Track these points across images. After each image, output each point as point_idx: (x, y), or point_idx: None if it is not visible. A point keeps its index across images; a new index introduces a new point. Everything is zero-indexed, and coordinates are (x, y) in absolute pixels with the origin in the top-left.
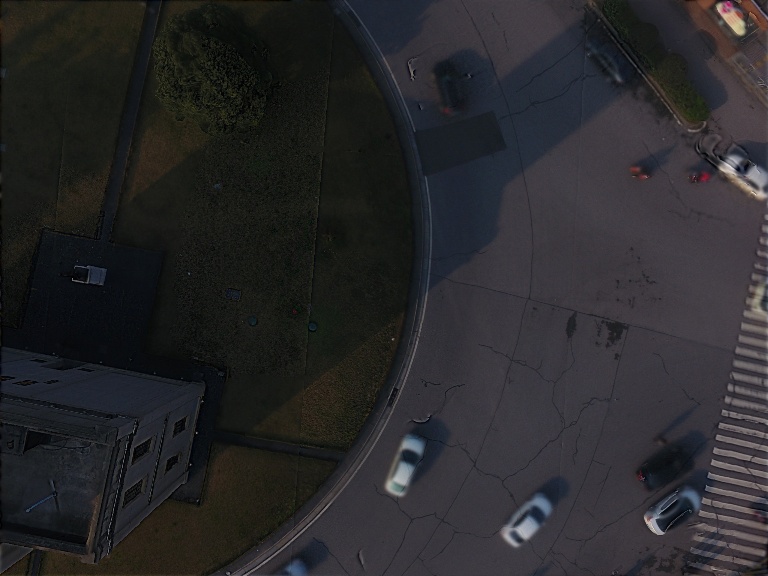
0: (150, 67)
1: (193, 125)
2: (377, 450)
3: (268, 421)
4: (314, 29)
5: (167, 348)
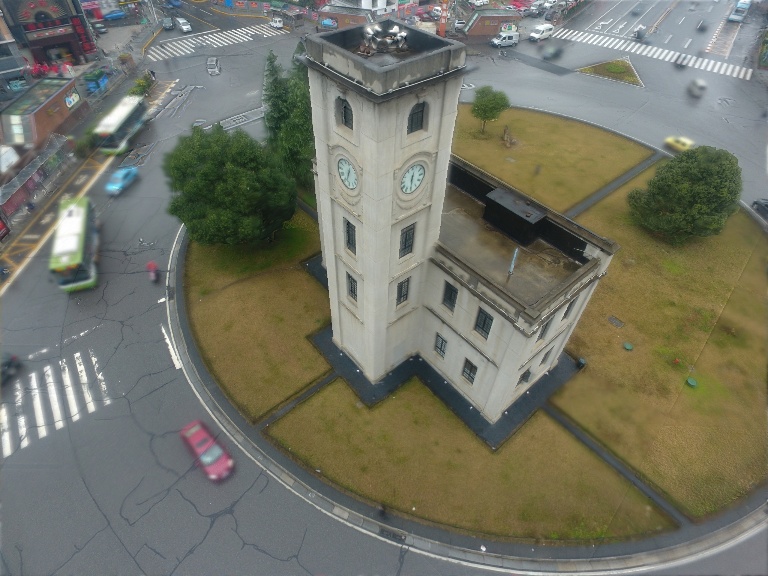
0: (609, 195)
1: (628, 228)
2: (737, 549)
3: (609, 428)
4: (744, 230)
5: None
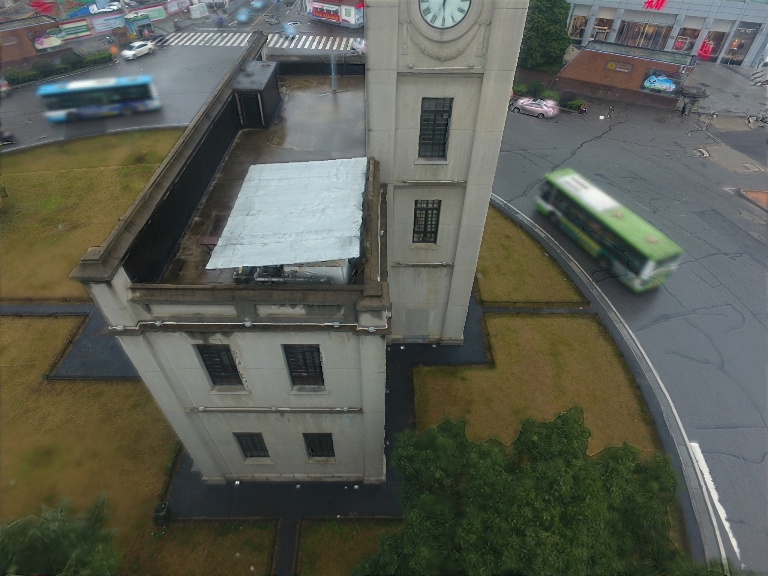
0: None
1: None
2: None
3: None
4: None
5: None
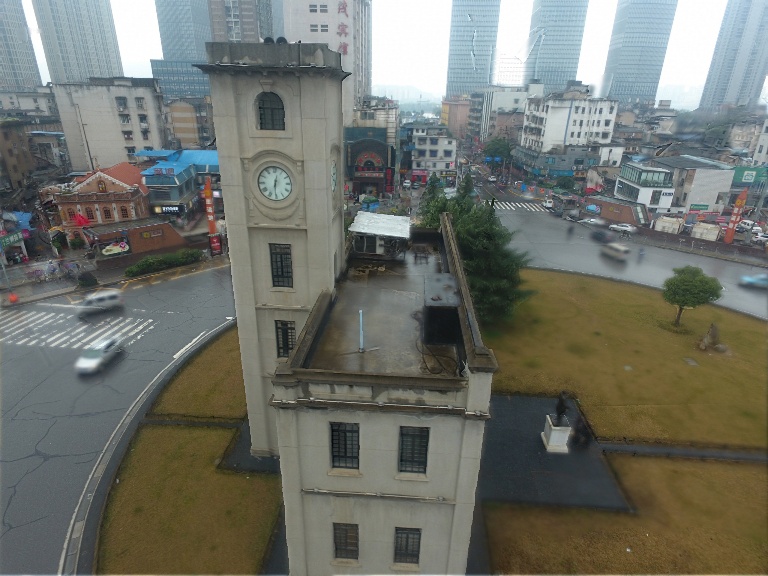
0: None
1: None
2: None
3: None
4: None
5: (501, 532)
